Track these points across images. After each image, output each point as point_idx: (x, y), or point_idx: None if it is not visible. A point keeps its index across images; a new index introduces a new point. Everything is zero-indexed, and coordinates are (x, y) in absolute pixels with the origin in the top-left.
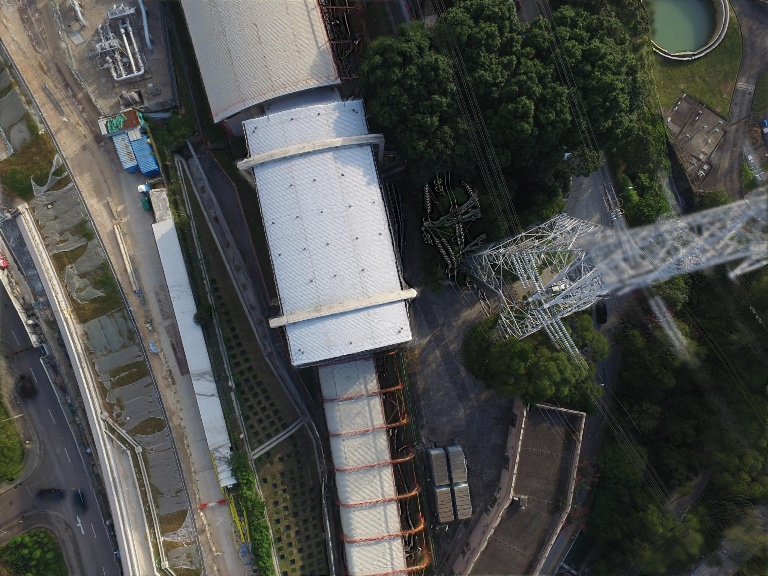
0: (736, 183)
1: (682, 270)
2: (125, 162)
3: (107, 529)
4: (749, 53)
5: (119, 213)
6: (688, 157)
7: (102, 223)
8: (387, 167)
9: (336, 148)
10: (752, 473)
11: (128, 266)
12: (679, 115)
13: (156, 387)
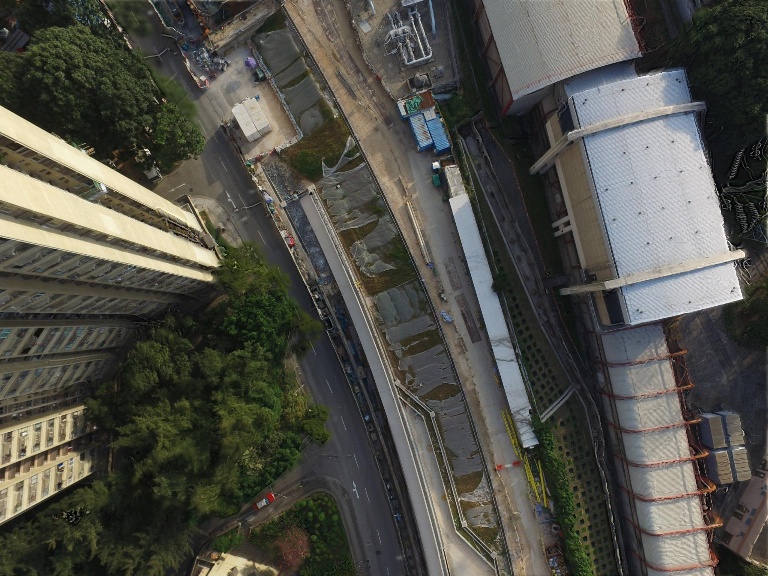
0: None
1: None
2: (421, 141)
3: (388, 493)
4: None
5: (409, 190)
6: None
7: (393, 200)
8: (706, 134)
9: (665, 116)
10: None
11: (420, 240)
12: None
13: (449, 354)
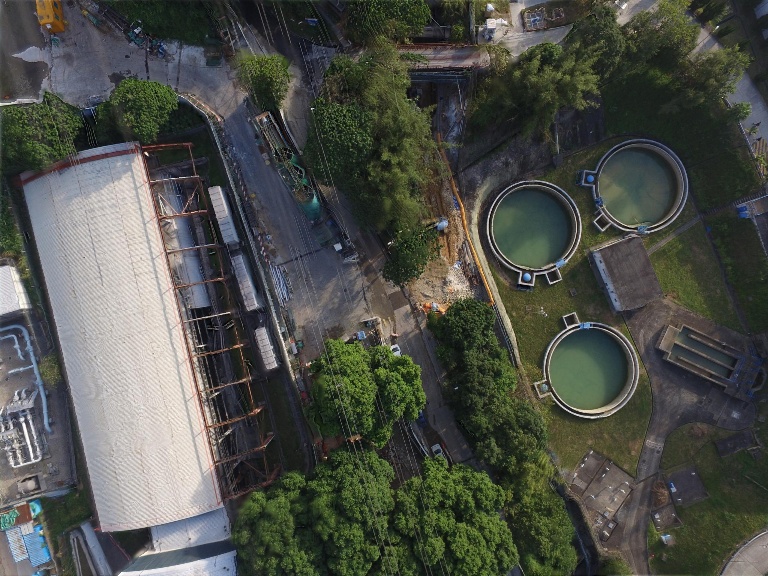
0: (641, 543)
1: None
2: (17, 555)
3: None
4: (659, 410)
5: None
6: (593, 517)
7: None
8: None
9: None
10: None
11: None
12: (586, 471)
13: None
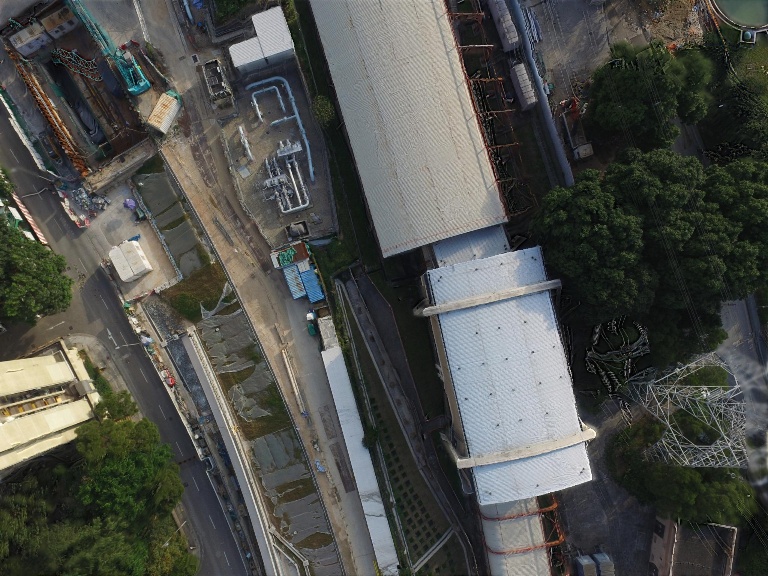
0: None
1: None
2: (295, 292)
3: None
4: None
5: (285, 337)
6: None
7: (270, 347)
8: (563, 310)
9: (518, 296)
10: None
11: (295, 389)
12: None
13: (322, 504)
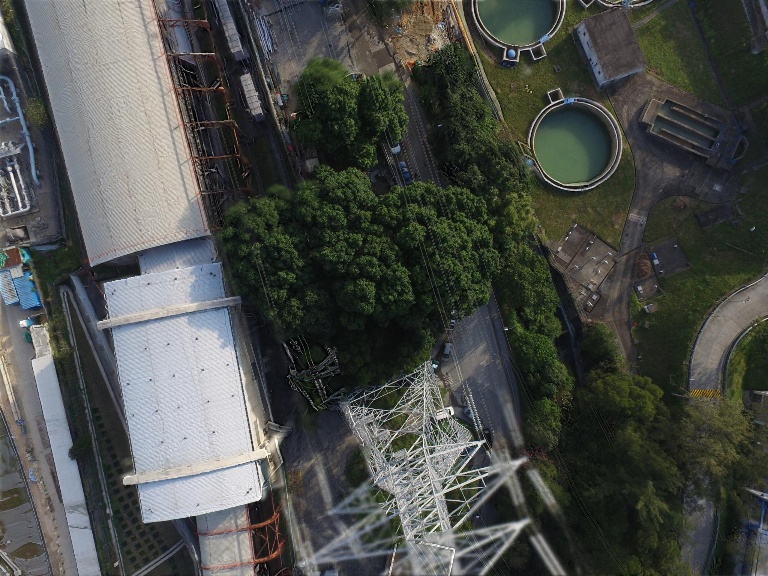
0: (624, 314)
1: (555, 411)
2: (7, 299)
3: None
4: (642, 184)
5: (4, 344)
6: (576, 287)
7: None
8: (245, 327)
9: (191, 312)
10: None
11: (11, 396)
12: (570, 244)
13: (35, 514)
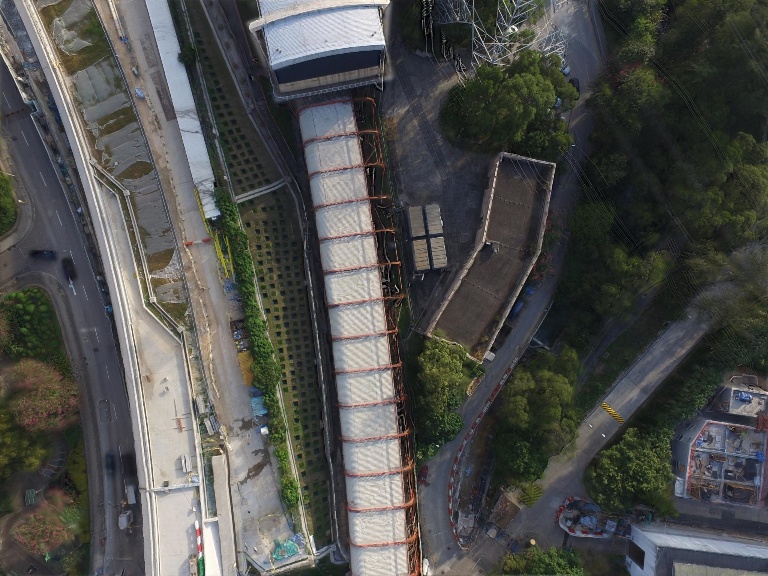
0: None
1: (650, 27)
2: None
3: (98, 284)
4: None
5: None
6: None
7: None
8: None
9: None
10: (712, 209)
11: (114, 13)
12: None
13: (143, 132)
